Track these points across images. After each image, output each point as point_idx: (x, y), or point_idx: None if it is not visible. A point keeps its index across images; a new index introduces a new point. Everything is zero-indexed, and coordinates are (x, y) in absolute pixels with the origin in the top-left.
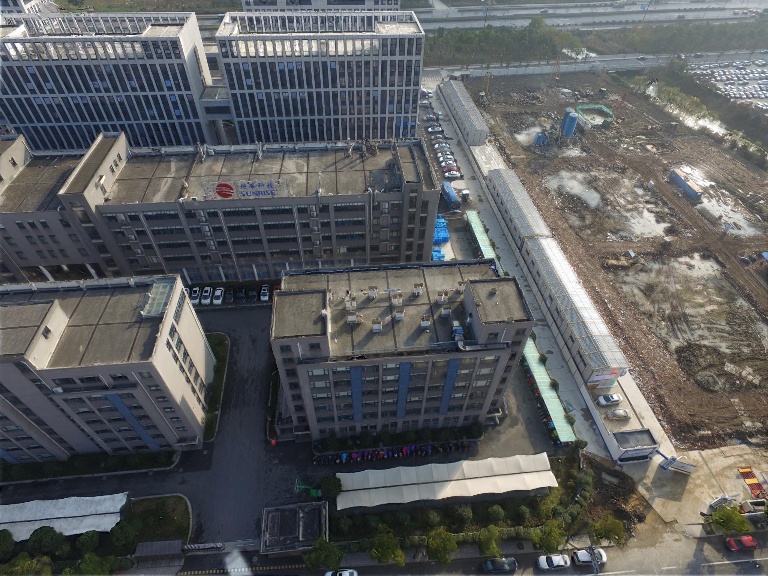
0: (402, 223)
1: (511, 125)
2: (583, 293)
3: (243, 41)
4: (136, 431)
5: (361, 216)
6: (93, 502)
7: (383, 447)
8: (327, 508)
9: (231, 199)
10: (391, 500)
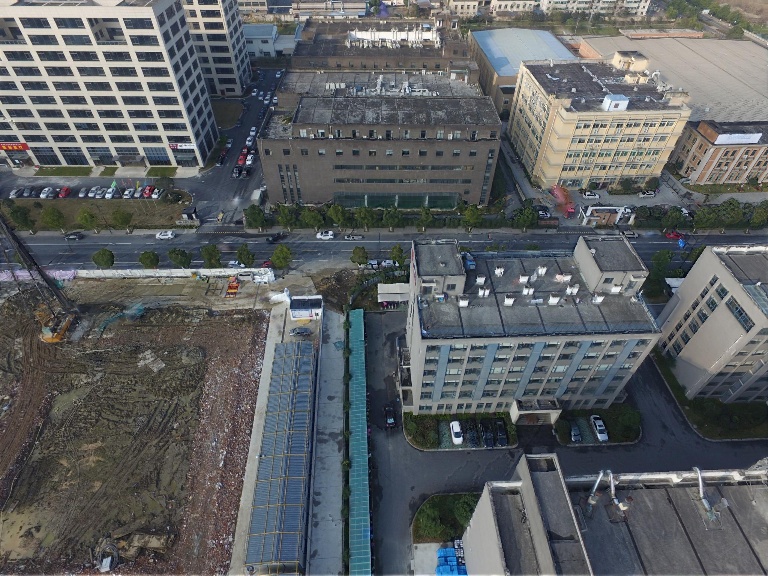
0: None
1: None
2: (268, 435)
3: None
4: None
5: None
6: None
7: None
8: None
9: None
10: None
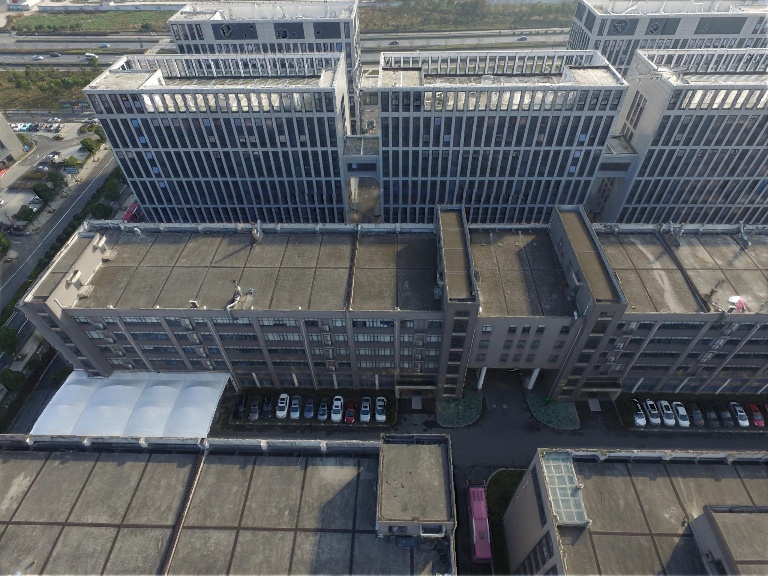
0: None
1: None
2: None
3: (703, 90)
4: None
5: None
6: None
7: None
8: None
9: None
10: None
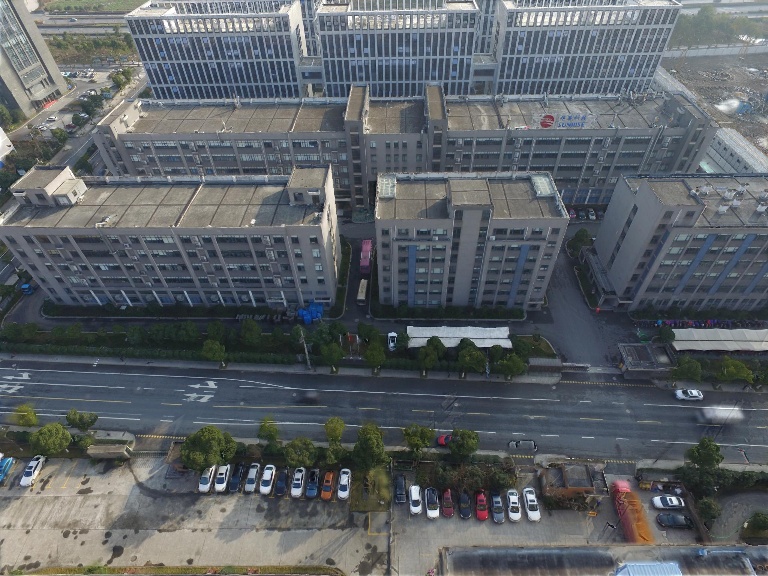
0: (678, 156)
1: (709, 97)
2: None
3: (527, 13)
4: (512, 285)
5: (643, 149)
6: (486, 330)
7: (688, 320)
8: None
9: (548, 129)
10: (718, 348)
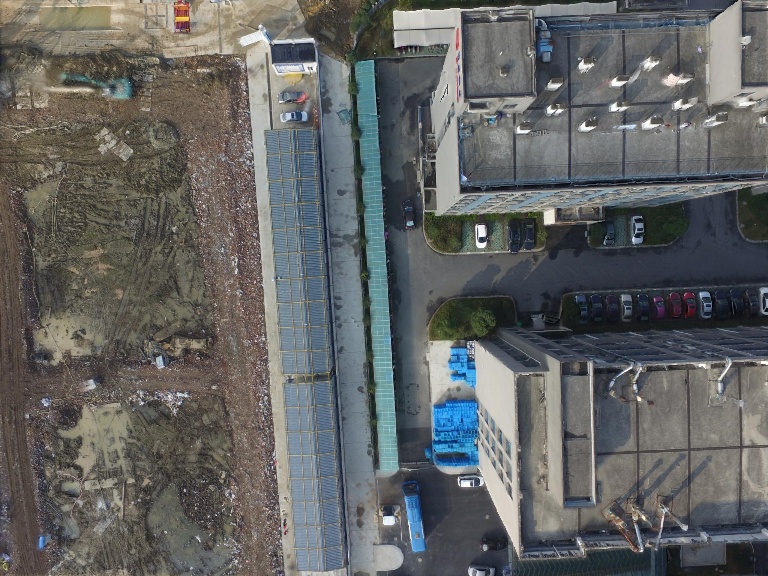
0: None
1: None
2: (279, 256)
3: None
4: None
5: None
6: None
7: None
8: (627, 2)
9: None
10: (564, 7)
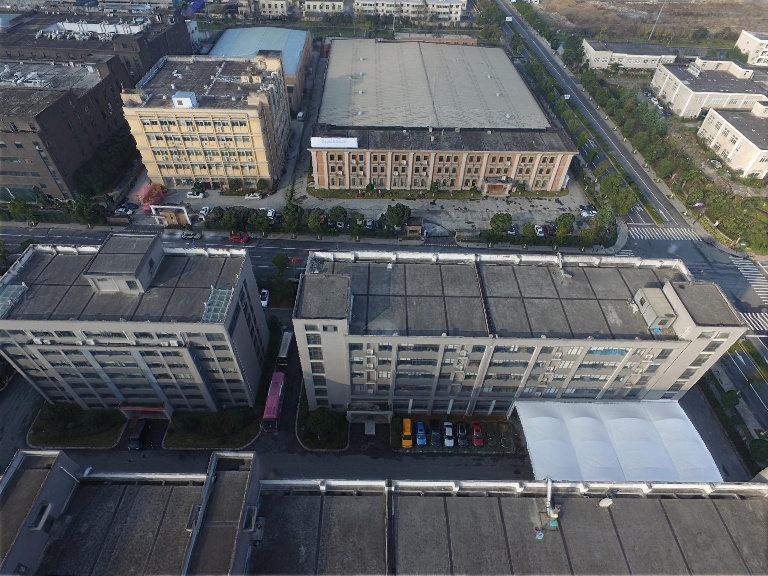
0: None
1: None
2: None
3: None
4: None
5: None
6: None
7: None
8: None
9: None
10: None
